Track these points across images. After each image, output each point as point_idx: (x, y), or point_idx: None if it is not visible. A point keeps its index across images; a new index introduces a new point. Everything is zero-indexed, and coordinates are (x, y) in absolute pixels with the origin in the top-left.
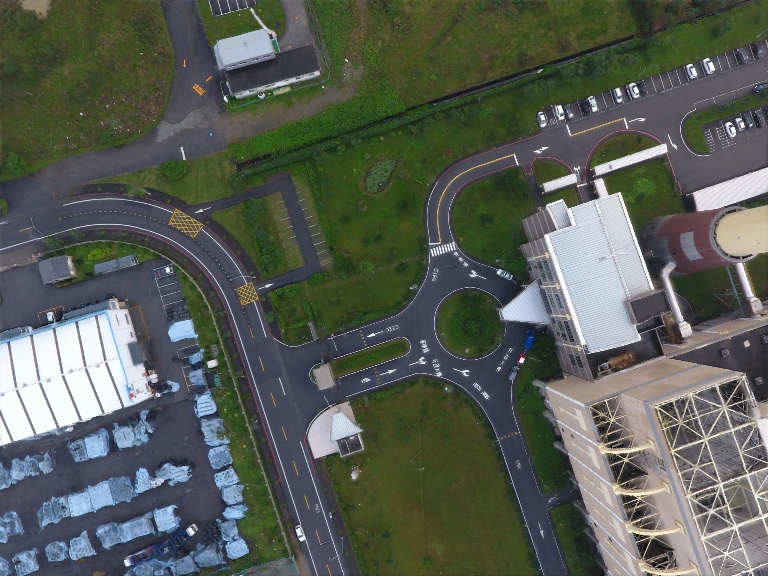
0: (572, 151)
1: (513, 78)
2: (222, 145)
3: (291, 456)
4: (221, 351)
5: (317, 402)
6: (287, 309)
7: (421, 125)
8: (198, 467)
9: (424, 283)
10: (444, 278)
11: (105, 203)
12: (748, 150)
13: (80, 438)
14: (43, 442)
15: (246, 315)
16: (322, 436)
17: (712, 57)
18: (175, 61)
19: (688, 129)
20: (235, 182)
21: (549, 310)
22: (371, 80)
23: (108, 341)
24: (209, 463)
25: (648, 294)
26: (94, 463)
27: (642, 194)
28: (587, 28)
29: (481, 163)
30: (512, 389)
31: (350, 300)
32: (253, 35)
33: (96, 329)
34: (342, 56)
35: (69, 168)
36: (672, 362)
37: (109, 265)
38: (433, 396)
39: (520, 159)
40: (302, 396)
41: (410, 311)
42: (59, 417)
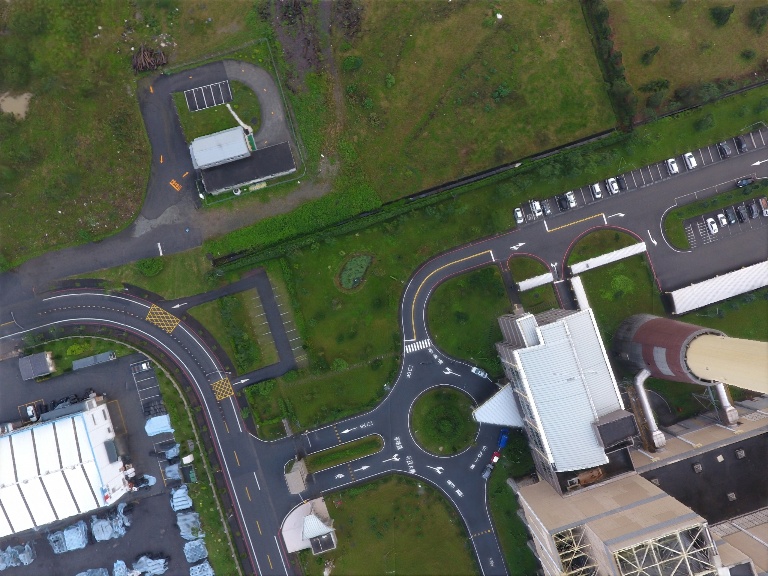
0: (549, 247)
1: (490, 172)
2: (198, 241)
3: (265, 550)
4: (197, 446)
5: (291, 497)
6: (262, 405)
7: (396, 223)
8: (174, 560)
9: (398, 380)
10: (418, 375)
11: (84, 298)
12: (730, 246)
13: (59, 530)
14: (24, 533)
15: (222, 410)
16: (296, 531)
17: (694, 151)
18: (152, 157)
19: (668, 225)
20: (210, 282)
21: (522, 414)
22: (347, 176)
23: (84, 443)
24: (185, 557)
25: (616, 418)
26: (73, 554)
27: (620, 292)
28: (566, 122)
29: (457, 259)
30: (486, 487)
31: (324, 396)
32: (227, 136)
33: (72, 430)
34: (318, 152)
35: (48, 263)
36: (641, 483)
37: (87, 362)
38: (406, 493)
39: (496, 255)
40: (276, 491)
41: (384, 408)
42: (37, 516)
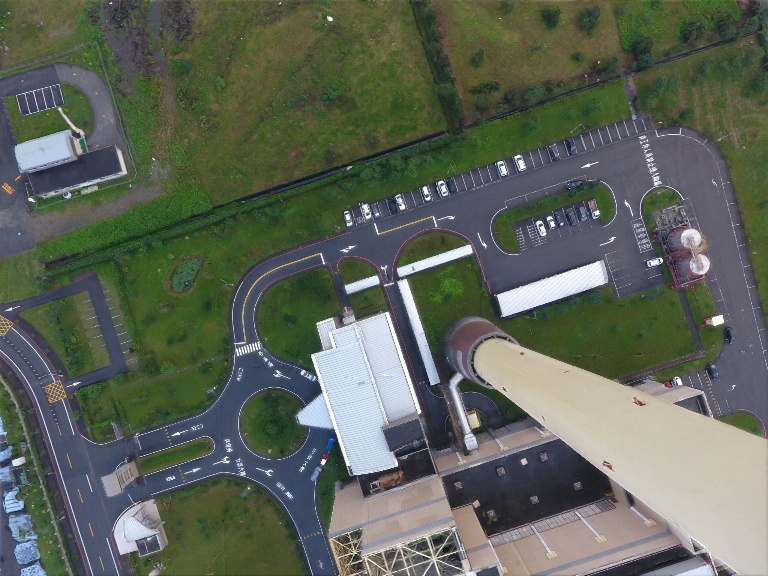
0: (379, 250)
1: (323, 175)
2: (31, 244)
3: (97, 552)
4: (28, 449)
5: (123, 499)
6: (94, 407)
7: (223, 226)
8: (7, 561)
9: (229, 382)
10: (249, 378)
11: None
12: (560, 249)
13: None
14: None
15: (54, 413)
16: None
17: (524, 153)
18: None
19: (498, 227)
20: (36, 285)
21: None
22: (177, 179)
23: None
24: (15, 559)
25: (403, 421)
26: None
27: (448, 295)
28: (396, 125)
29: (287, 262)
30: (315, 489)
31: (155, 399)
32: (50, 140)
33: None
34: (148, 155)
35: None
36: (434, 486)
37: None
38: (236, 495)
39: (326, 258)
40: None
41: (214, 410)
42: None
